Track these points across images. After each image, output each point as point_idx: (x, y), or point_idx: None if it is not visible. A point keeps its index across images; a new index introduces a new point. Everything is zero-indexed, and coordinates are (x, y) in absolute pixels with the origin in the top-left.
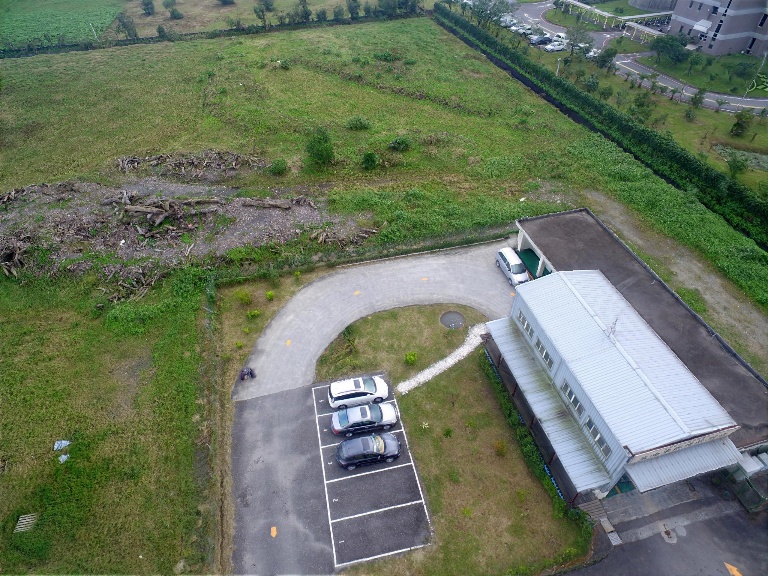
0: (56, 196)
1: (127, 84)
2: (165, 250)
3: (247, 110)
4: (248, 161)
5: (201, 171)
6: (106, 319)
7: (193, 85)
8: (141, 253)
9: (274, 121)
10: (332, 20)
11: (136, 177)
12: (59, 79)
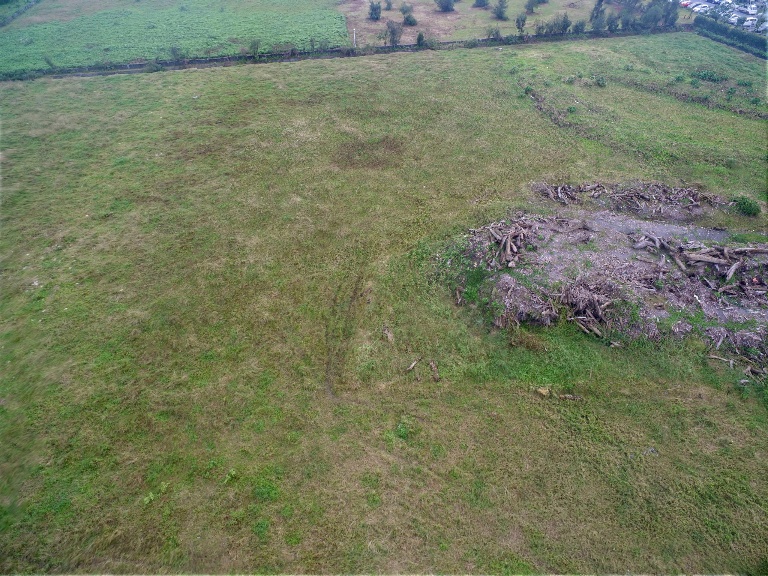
0: (573, 235)
1: (440, 97)
2: (761, 312)
3: (626, 133)
4: (705, 197)
5: (660, 207)
6: (766, 401)
7: (517, 101)
8: (738, 314)
9: (672, 148)
10: (589, 32)
11: (584, 210)
12: (358, 88)
